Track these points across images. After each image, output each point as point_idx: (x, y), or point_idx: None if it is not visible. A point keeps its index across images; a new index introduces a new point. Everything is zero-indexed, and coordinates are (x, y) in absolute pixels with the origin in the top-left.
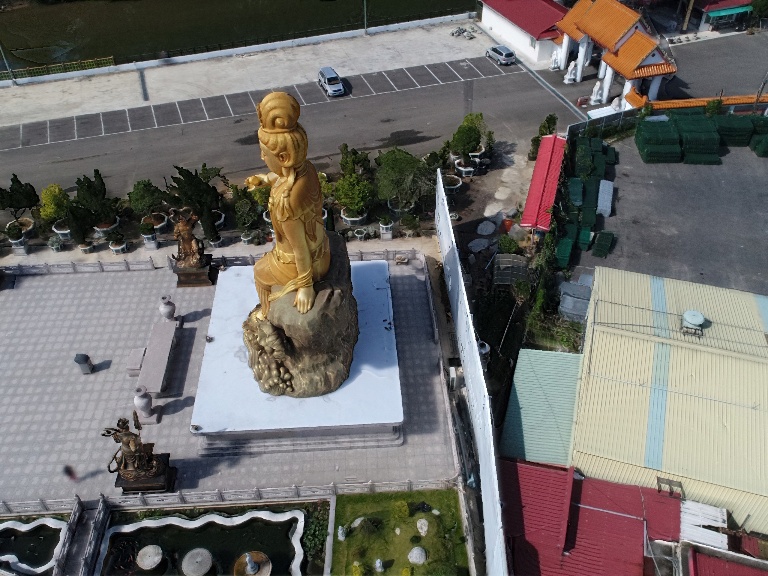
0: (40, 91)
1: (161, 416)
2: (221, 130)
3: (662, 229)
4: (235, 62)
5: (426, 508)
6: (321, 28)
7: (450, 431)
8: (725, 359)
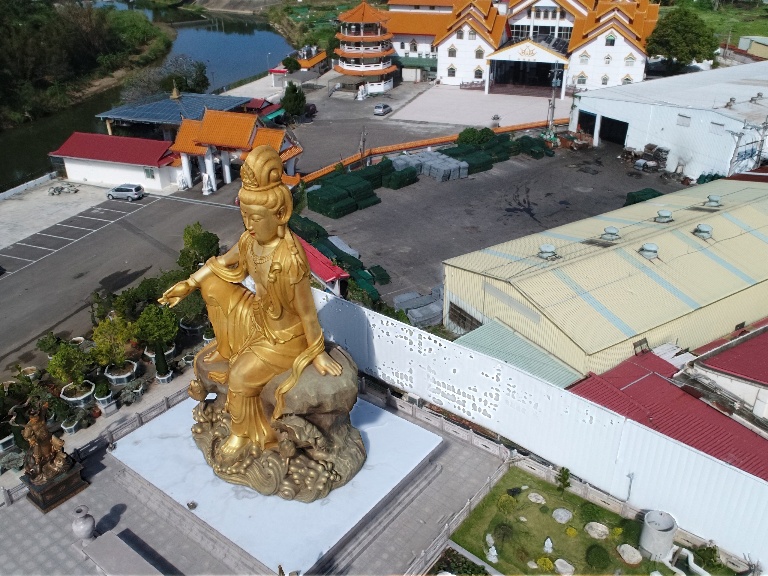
0: None
1: None
2: None
3: (400, 250)
4: None
5: (516, 491)
6: None
7: (460, 435)
8: (589, 260)
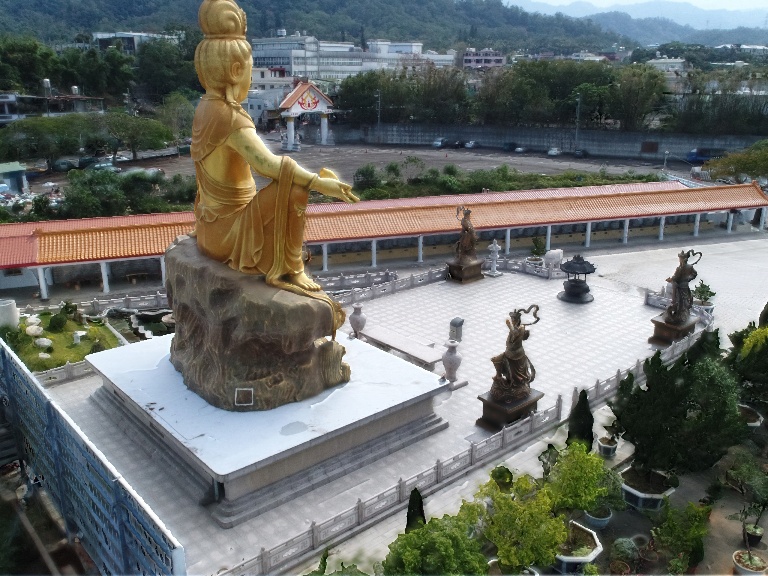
0: None
1: None
2: None
3: None
4: None
5: None
6: None
7: None
8: None
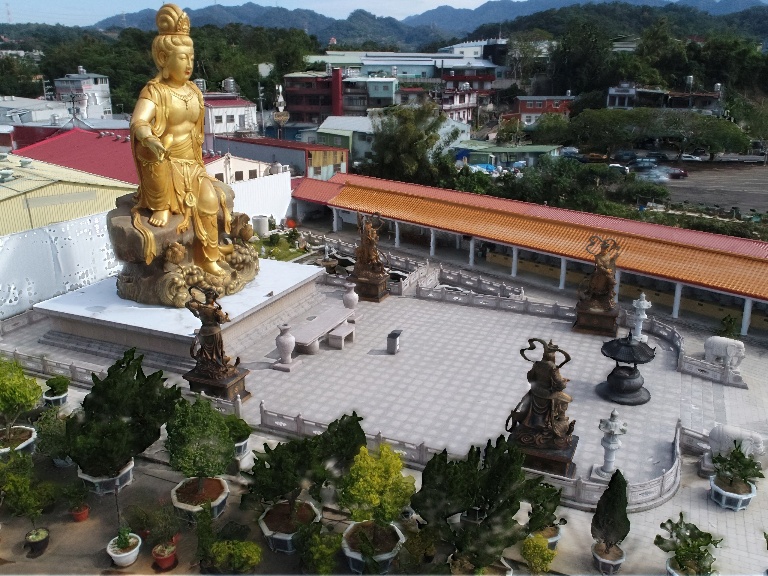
0: None
1: None
2: None
3: None
4: None
5: None
6: None
7: None
8: None
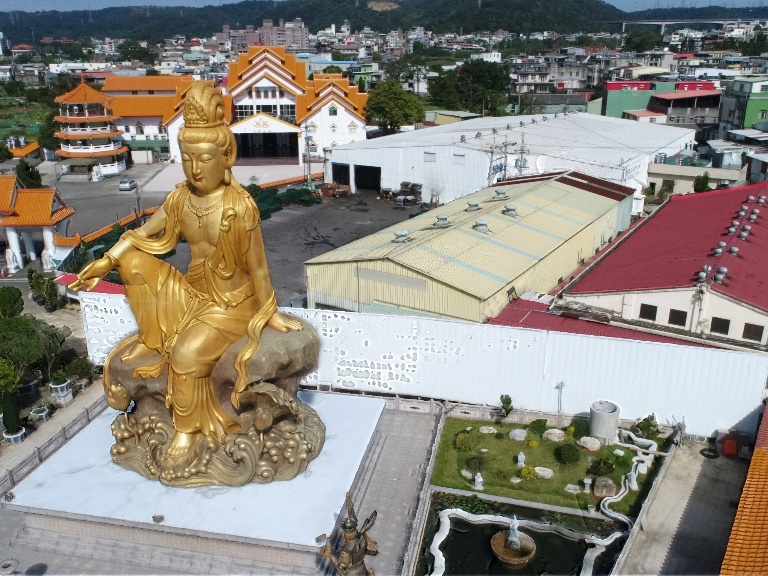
0: None
1: None
2: None
3: None
4: None
5: None
6: None
7: (386, 405)
8: (441, 236)
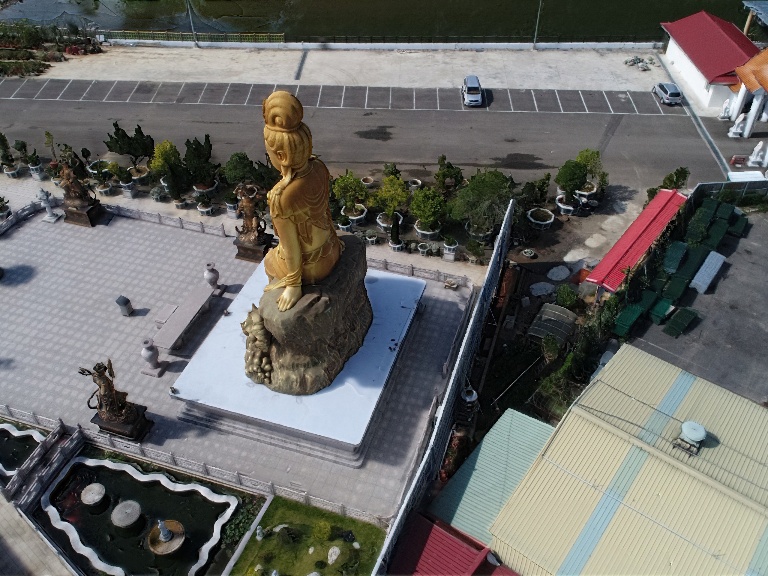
0: (214, 56)
1: (164, 371)
2: (348, 119)
3: (762, 323)
4: (393, 56)
5: (349, 538)
6: (488, 36)
7: None
8: (707, 489)
